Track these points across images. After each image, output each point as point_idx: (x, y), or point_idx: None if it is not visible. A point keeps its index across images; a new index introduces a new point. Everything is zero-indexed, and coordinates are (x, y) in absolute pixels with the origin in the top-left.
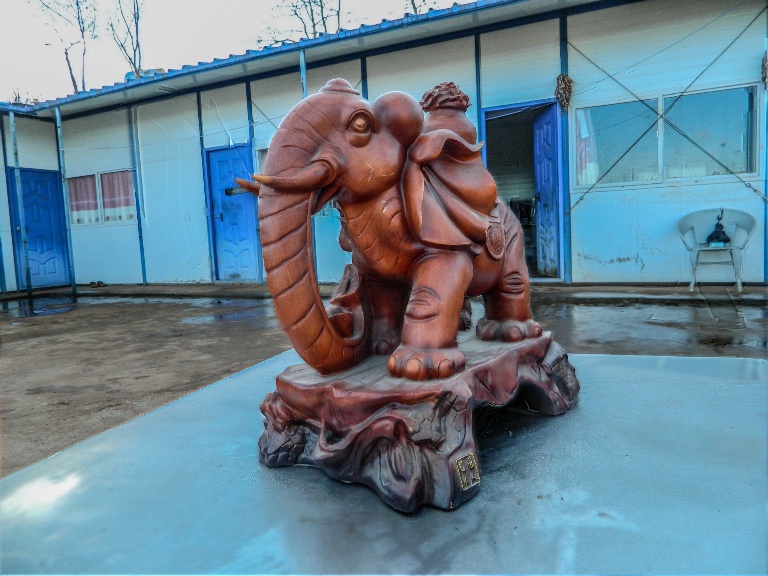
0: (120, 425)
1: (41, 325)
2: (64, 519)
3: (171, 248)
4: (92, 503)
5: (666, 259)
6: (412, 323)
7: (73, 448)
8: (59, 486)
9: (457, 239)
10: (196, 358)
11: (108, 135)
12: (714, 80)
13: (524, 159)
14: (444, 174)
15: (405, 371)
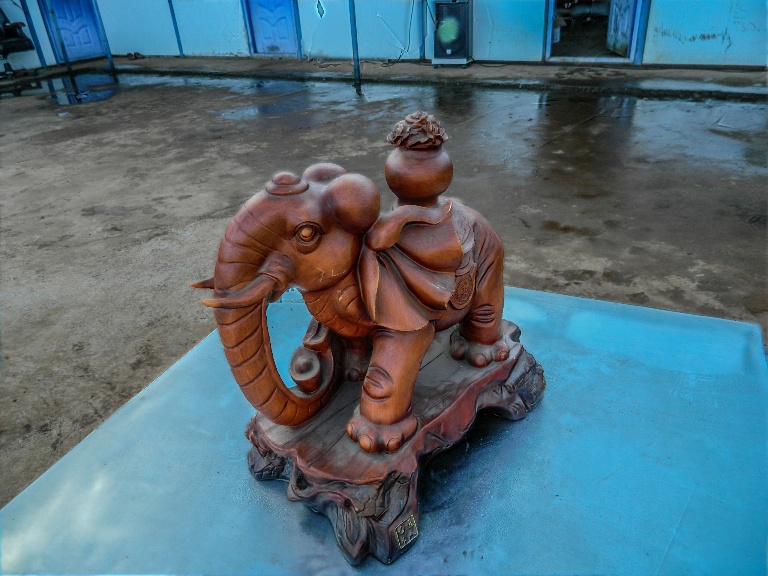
0: (143, 390)
1: (86, 117)
2: (98, 535)
3: (203, 16)
4: (118, 515)
5: (759, 37)
6: (367, 399)
7: (104, 425)
8: (94, 486)
9: (412, 325)
10: (235, 172)
11: None
12: None
13: None
14: (406, 244)
15: (359, 443)
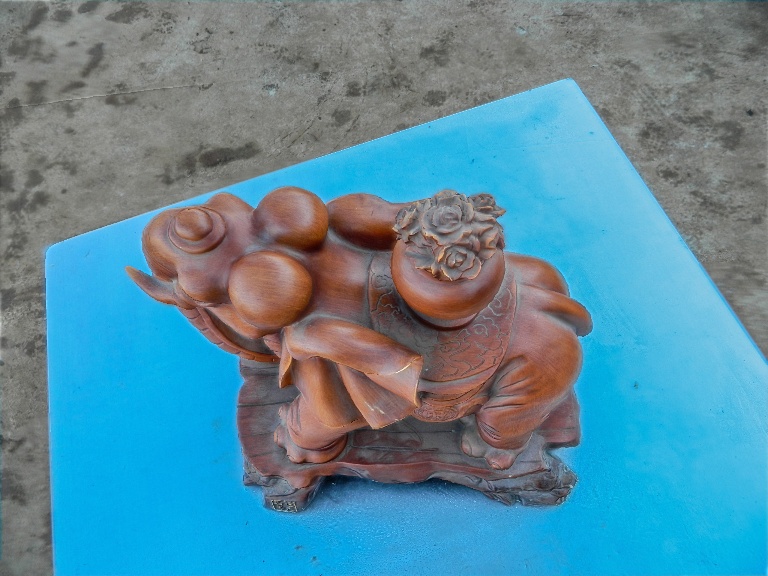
0: (283, 169)
1: None
2: None
3: None
4: None
5: None
6: None
7: (234, 188)
8: None
9: (321, 418)
10: None
11: None
12: None
13: None
14: None
15: None
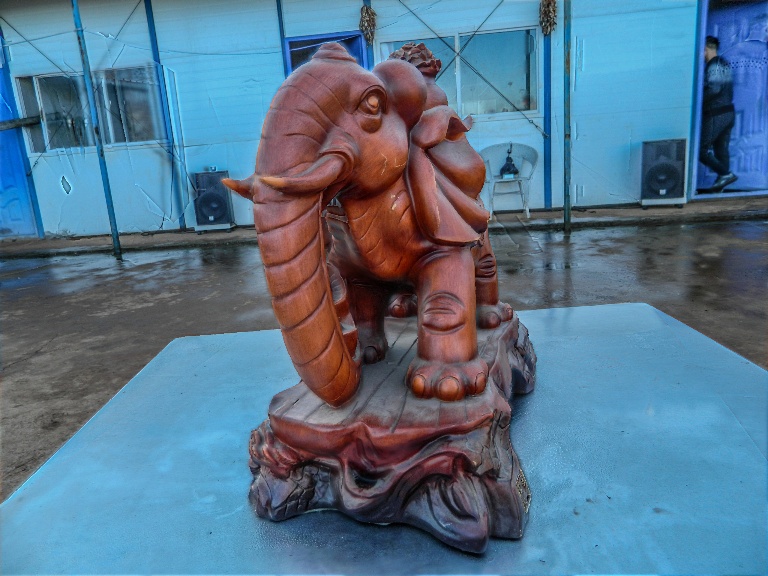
0: (14, 493)
1: None
2: None
3: None
4: None
5: None
6: (436, 335)
7: None
8: None
9: (471, 234)
10: None
11: None
12: (501, 21)
13: None
14: (439, 157)
15: (440, 392)
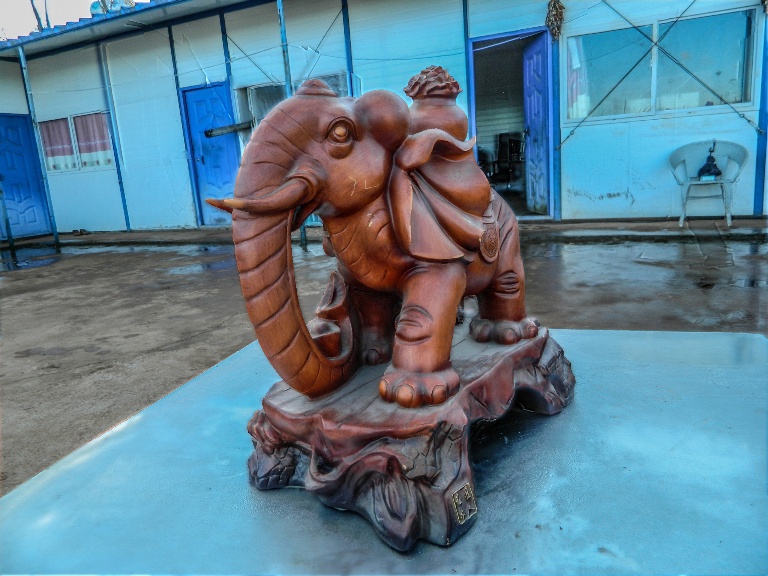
0: None
1: (25, 280)
2: (49, 564)
3: (153, 193)
4: (78, 541)
5: (656, 194)
6: (403, 345)
7: (57, 465)
8: (43, 518)
9: (449, 252)
10: (185, 313)
11: (77, 75)
12: (712, 3)
13: (513, 92)
14: (434, 177)
15: (397, 398)
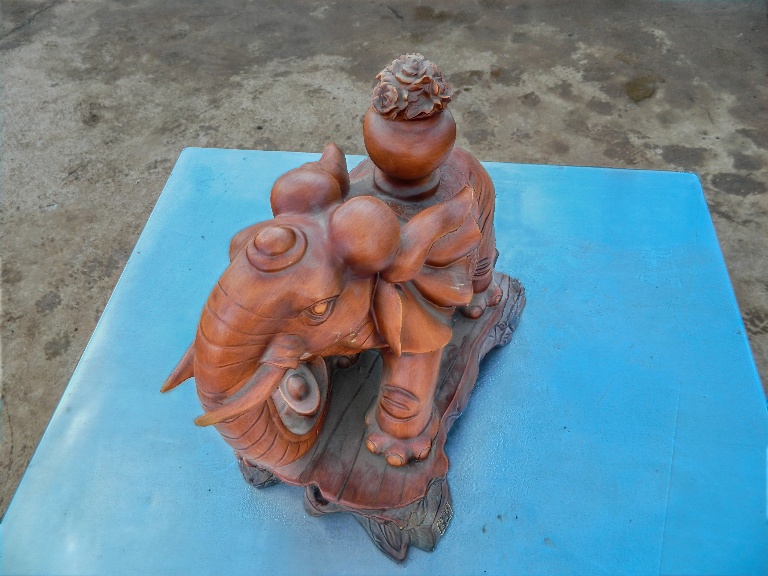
0: (62, 397)
1: None
2: None
3: None
4: (115, 575)
5: None
6: (390, 420)
7: (37, 460)
8: (65, 546)
9: (438, 343)
10: None
11: None
12: None
13: None
14: None
15: None
